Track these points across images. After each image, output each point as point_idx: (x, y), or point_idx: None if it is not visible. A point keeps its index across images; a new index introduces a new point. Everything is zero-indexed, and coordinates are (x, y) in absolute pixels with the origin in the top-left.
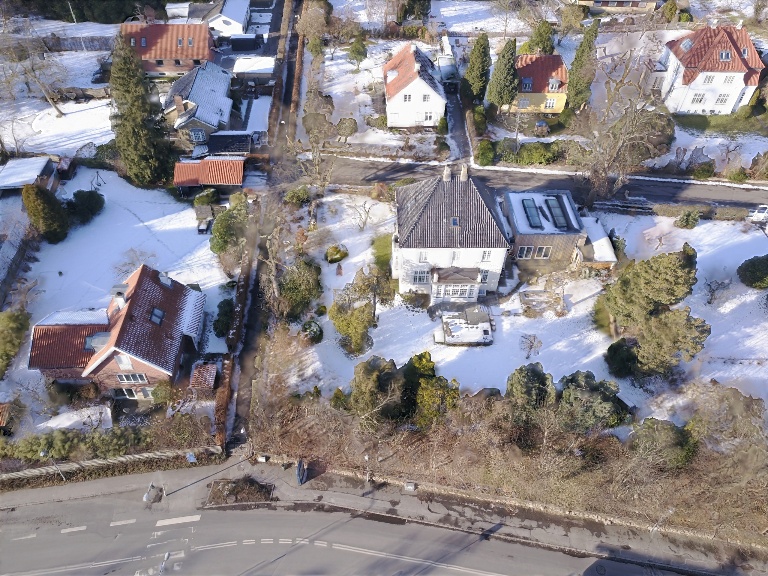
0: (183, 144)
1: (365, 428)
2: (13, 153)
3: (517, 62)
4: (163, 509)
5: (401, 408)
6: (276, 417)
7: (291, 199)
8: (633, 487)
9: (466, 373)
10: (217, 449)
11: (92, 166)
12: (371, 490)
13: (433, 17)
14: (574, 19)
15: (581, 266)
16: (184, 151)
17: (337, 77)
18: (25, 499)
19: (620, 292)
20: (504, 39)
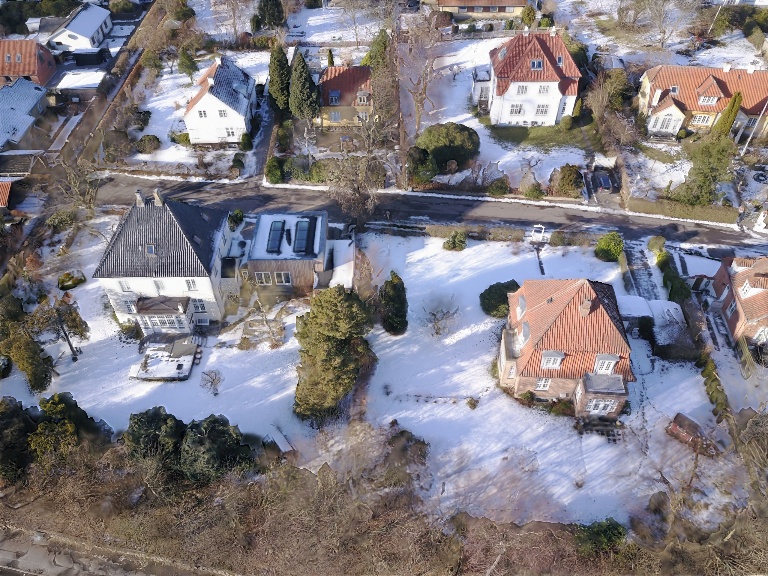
0: None
1: None
2: None
3: (323, 74)
4: None
5: None
6: None
7: (52, 222)
8: (240, 544)
9: None
10: None
11: None
12: (2, 539)
13: (296, 27)
14: (416, 27)
15: (316, 293)
16: None
17: (167, 91)
18: None
19: (300, 326)
20: (357, 48)
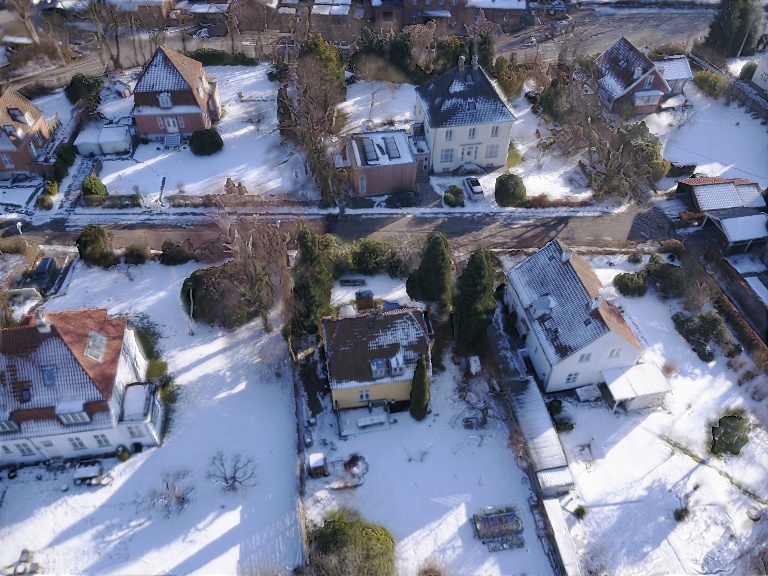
0: None
1: None
2: None
3: (415, 310)
4: None
5: None
6: None
7: None
8: None
9: None
10: None
11: None
12: None
13: None
14: None
15: None
16: None
17: None
18: None
19: None
20: None
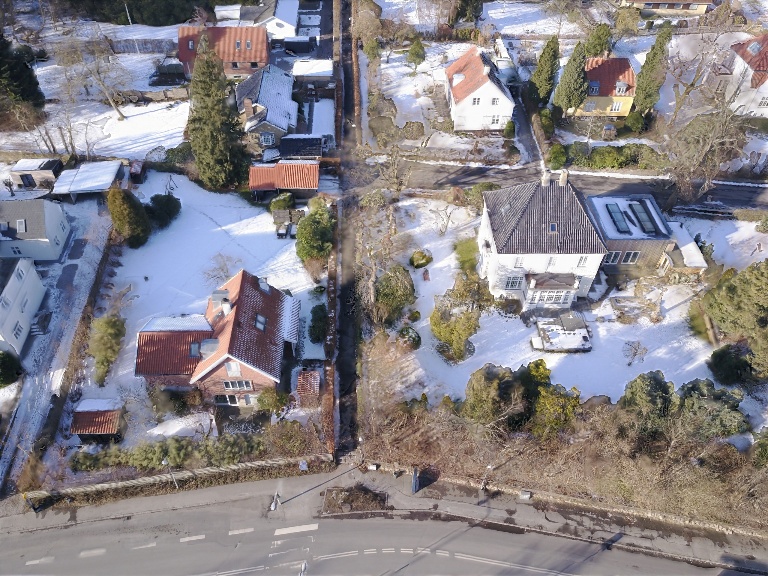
0: (252, 148)
1: (492, 437)
2: (83, 157)
3: None
4: (279, 518)
5: (514, 416)
6: (384, 424)
7: (368, 203)
8: (761, 497)
9: (568, 380)
10: (328, 457)
11: (162, 170)
12: (486, 499)
13: (482, 19)
14: (631, 22)
15: (670, 271)
16: (252, 155)
17: (395, 80)
18: (140, 507)
19: (727, 299)
20: None
